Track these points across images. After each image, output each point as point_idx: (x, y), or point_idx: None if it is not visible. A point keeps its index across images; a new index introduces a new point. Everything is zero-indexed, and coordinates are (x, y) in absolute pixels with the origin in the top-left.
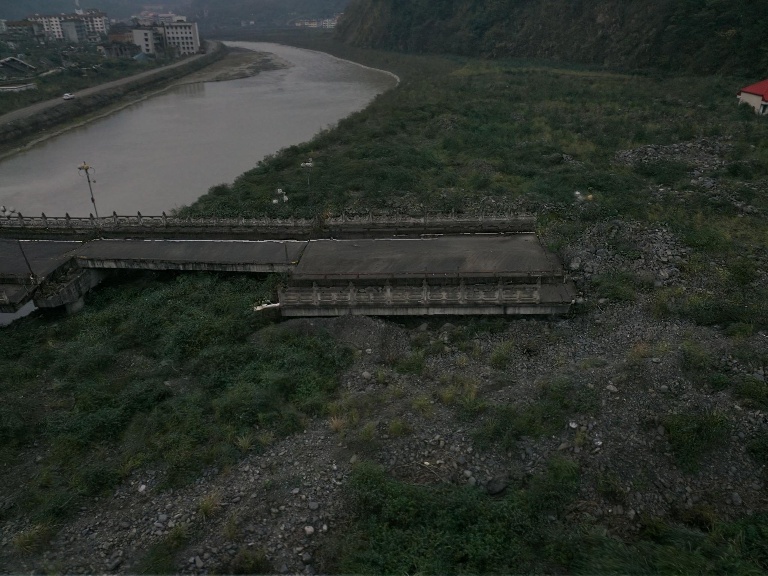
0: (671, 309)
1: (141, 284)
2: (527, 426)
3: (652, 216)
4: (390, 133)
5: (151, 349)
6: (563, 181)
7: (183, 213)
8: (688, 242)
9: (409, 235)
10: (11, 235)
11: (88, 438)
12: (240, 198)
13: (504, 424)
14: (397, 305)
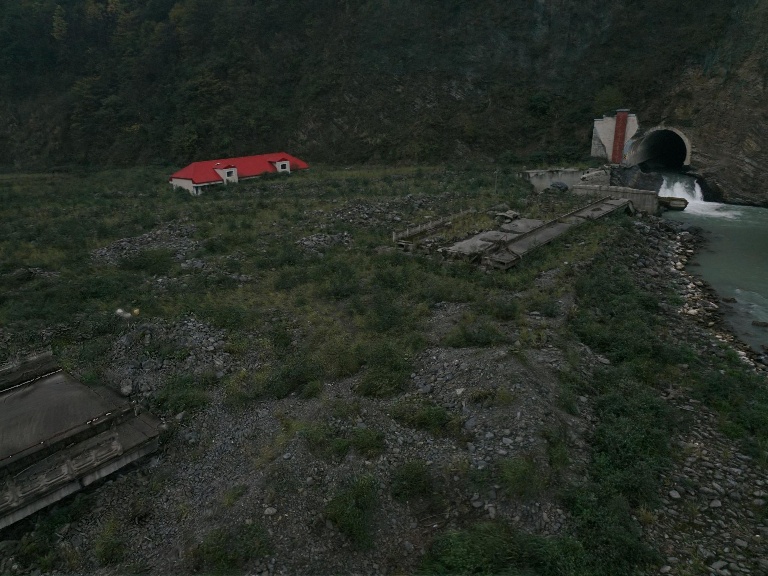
0: (249, 395)
1: None
2: None
3: (167, 309)
4: None
5: None
6: (48, 298)
7: None
8: (221, 324)
9: None
10: None
11: None
12: None
13: None
14: None
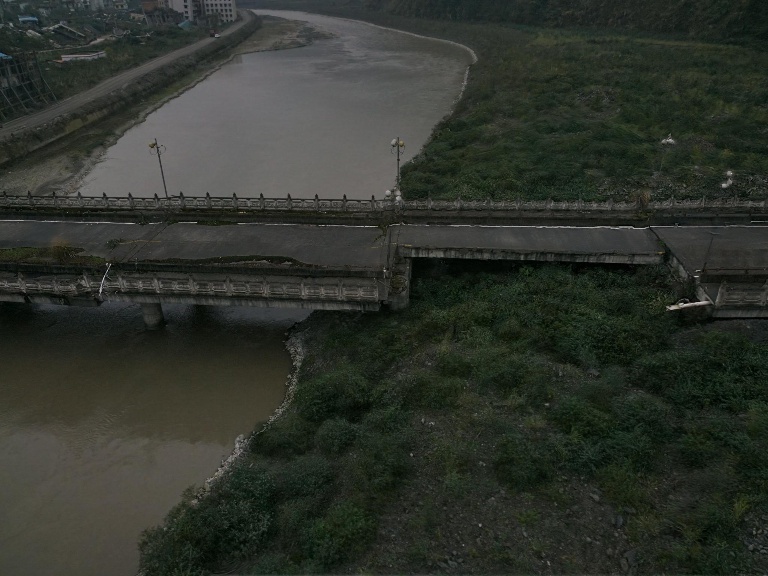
0: None
1: (463, 275)
2: None
3: None
4: (551, 105)
5: (560, 354)
6: None
7: (405, 193)
8: None
9: None
10: (292, 219)
11: (632, 471)
12: (479, 177)
13: None
14: None
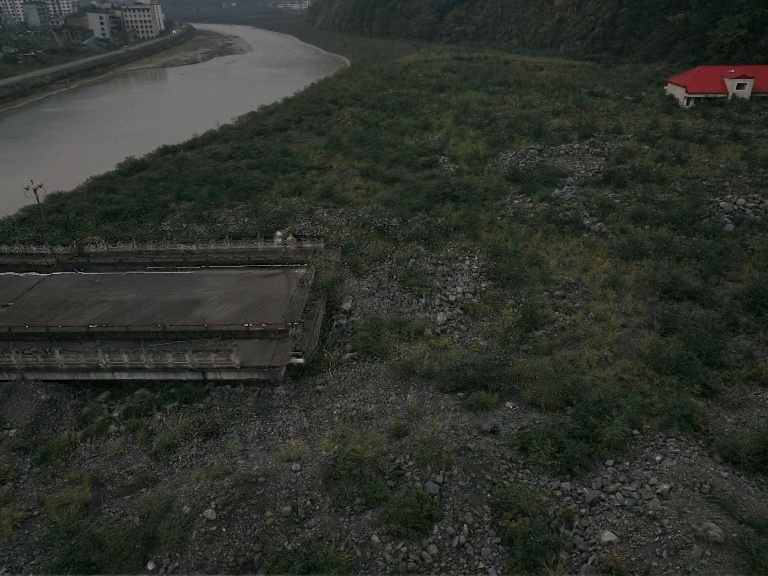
0: (417, 370)
1: None
2: (106, 561)
3: (487, 236)
4: (279, 130)
5: None
6: (417, 190)
7: None
8: (489, 275)
9: (167, 267)
10: None
11: None
12: (46, 212)
13: (85, 555)
14: (73, 369)
